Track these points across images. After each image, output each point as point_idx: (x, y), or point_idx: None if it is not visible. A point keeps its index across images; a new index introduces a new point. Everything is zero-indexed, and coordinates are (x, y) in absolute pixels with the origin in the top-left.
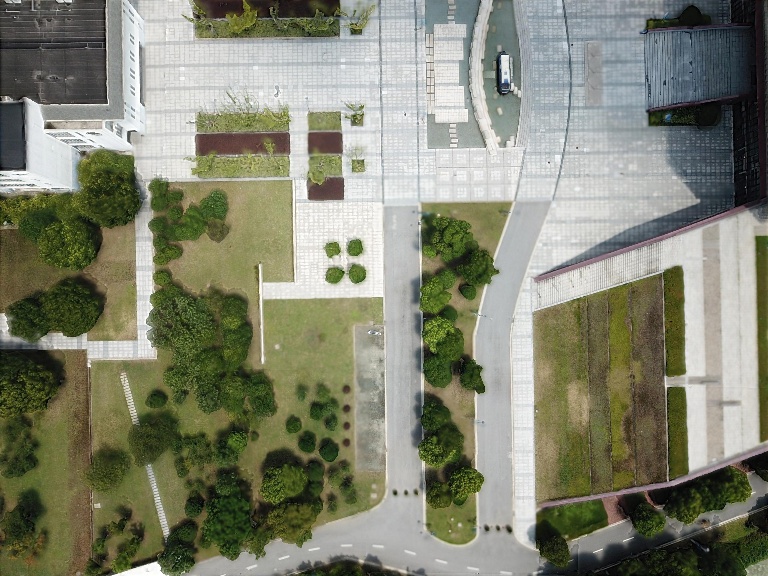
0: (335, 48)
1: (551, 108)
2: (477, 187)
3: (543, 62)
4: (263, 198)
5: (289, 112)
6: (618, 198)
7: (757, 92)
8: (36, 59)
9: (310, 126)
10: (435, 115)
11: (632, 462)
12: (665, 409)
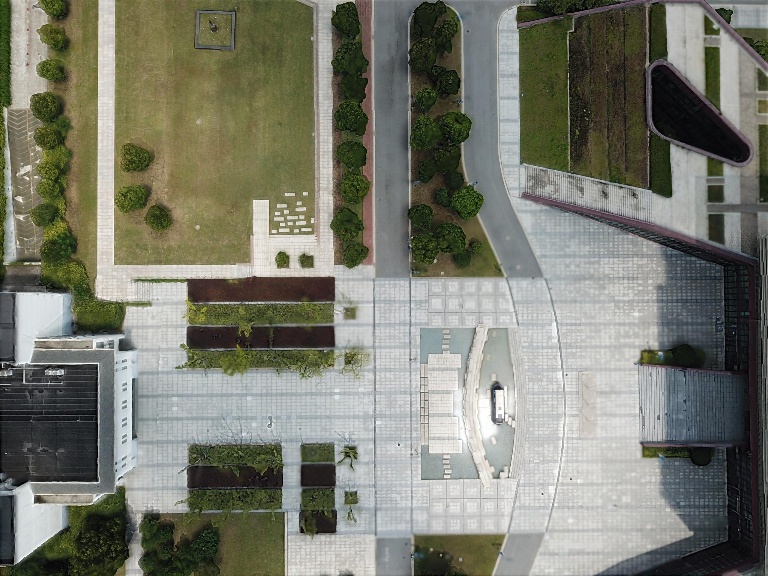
0: (329, 378)
1: (545, 439)
2: (470, 519)
3: (537, 392)
4: (255, 530)
5: (282, 443)
6: (611, 530)
7: (750, 449)
8: (27, 432)
9: (303, 458)
10: (429, 446)
11: None
12: None
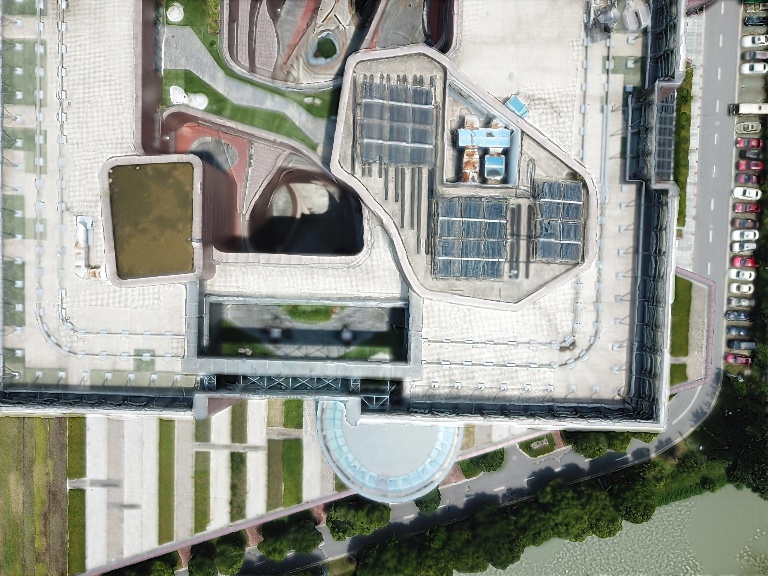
0: None
1: None
2: None
3: None
4: None
5: None
6: None
7: None
8: None
9: None
10: None
11: (47, 556)
12: (67, 509)
